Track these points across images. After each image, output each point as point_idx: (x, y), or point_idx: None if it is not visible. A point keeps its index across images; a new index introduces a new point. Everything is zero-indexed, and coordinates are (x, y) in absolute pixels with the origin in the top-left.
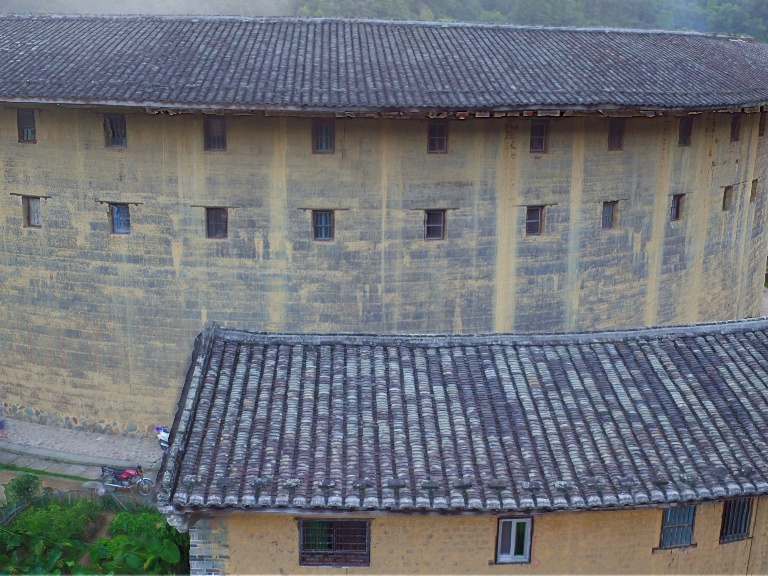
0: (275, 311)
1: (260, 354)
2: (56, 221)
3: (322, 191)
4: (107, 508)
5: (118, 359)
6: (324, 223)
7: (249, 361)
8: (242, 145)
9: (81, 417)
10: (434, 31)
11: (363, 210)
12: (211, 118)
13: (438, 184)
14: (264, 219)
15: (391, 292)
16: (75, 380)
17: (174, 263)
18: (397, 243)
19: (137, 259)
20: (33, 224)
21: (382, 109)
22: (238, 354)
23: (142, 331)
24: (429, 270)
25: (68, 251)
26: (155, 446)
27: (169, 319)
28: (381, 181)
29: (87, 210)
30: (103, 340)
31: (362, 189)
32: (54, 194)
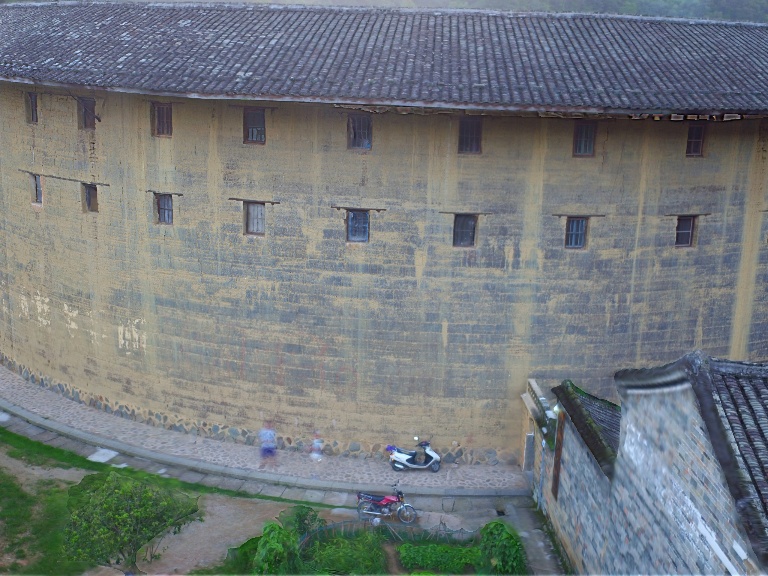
0: (520, 323)
1: (765, 388)
2: (283, 228)
3: (579, 196)
4: (381, 539)
5: (345, 375)
6: (575, 230)
7: (758, 397)
8: (500, 148)
9: (296, 437)
10: (685, 28)
11: (619, 216)
12: (468, 119)
13: (693, 189)
14: (517, 226)
15: (639, 302)
16: (293, 398)
17: (416, 273)
18: (649, 251)
19: (375, 269)
20: (251, 231)
21: (685, 112)
22: (742, 389)
23: (375, 345)
24: (677, 278)
25: (295, 260)
26: (384, 467)
27: (406, 332)
28: (639, 186)
29: (321, 217)
30: (329, 355)
31: (620, 194)
32: (283, 199)
